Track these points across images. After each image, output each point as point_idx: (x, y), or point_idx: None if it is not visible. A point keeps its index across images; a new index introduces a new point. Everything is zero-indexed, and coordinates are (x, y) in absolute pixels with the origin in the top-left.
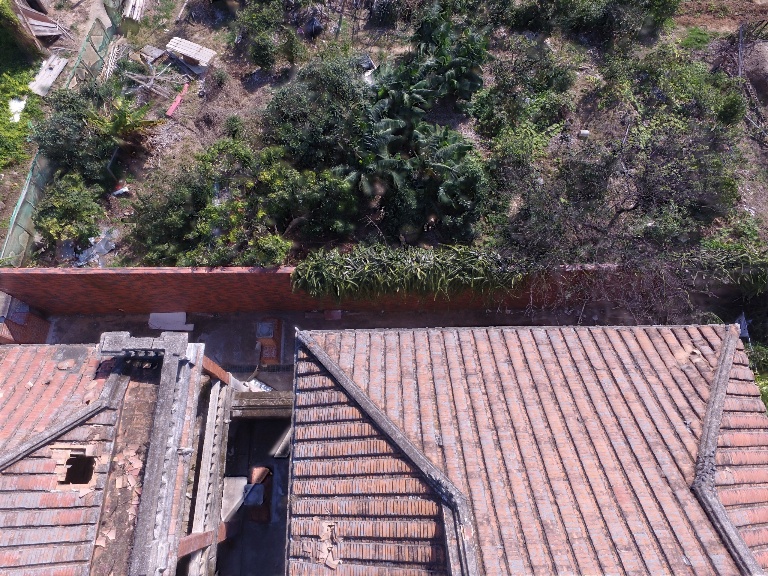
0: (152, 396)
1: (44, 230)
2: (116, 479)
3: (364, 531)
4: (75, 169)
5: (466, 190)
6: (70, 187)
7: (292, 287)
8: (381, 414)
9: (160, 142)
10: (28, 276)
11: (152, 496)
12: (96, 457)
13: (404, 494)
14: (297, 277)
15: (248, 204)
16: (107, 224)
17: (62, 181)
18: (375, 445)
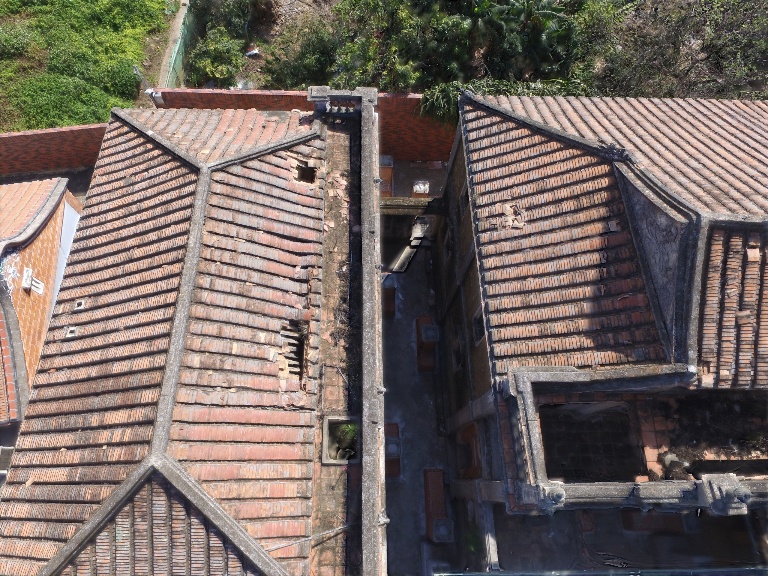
0: (345, 142)
1: (197, 72)
2: (328, 190)
3: (545, 199)
4: (221, 24)
5: (562, 42)
6: (218, 38)
7: (420, 110)
8: (549, 126)
9: (284, 13)
10: (196, 97)
11: (369, 187)
12: (316, 168)
13: (577, 169)
14: (424, 102)
15: (381, 42)
16: (243, 77)
17: (214, 30)
18: (546, 146)
